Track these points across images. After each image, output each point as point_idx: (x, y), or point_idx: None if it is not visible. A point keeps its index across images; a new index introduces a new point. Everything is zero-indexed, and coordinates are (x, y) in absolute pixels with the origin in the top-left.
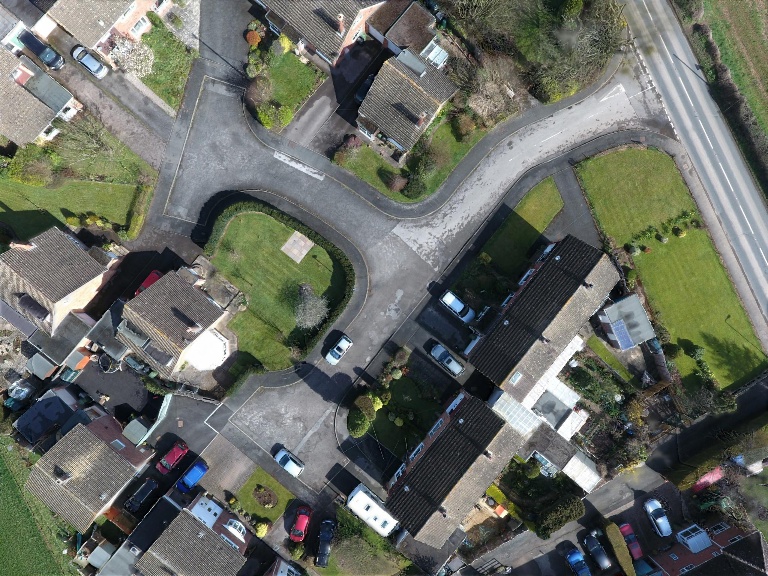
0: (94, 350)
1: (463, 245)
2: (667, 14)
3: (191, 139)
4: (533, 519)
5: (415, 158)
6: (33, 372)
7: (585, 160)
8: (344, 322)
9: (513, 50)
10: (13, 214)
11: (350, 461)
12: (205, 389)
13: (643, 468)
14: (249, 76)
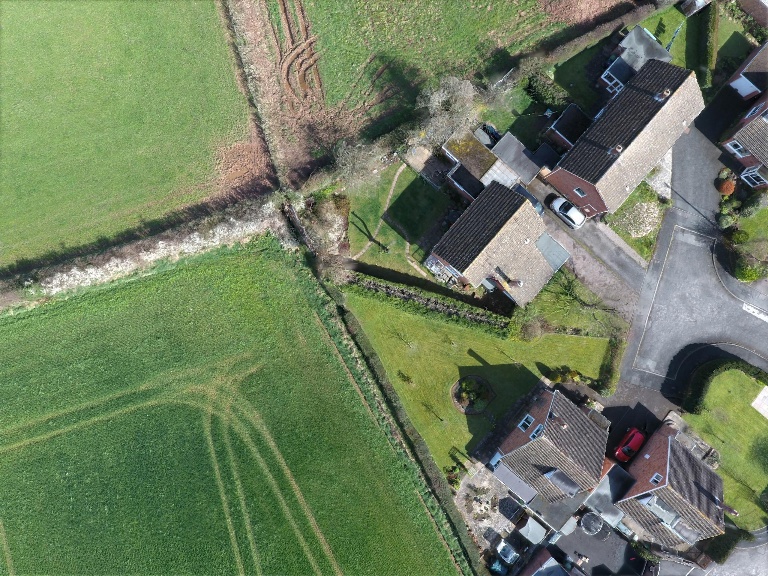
0: None
1: None
2: None
3: (661, 290)
4: None
5: None
6: (526, 536)
7: None
8: None
9: None
10: (490, 368)
11: None
12: (680, 550)
13: None
14: (722, 227)
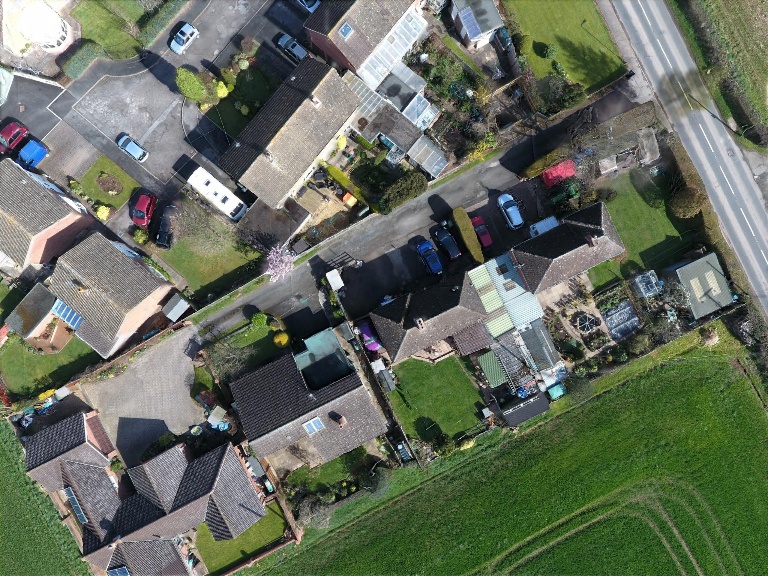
0: None
1: None
2: None
3: None
4: None
5: None
6: None
7: None
8: (191, 14)
9: None
10: None
11: (197, 152)
12: (48, 75)
13: (498, 167)
14: None
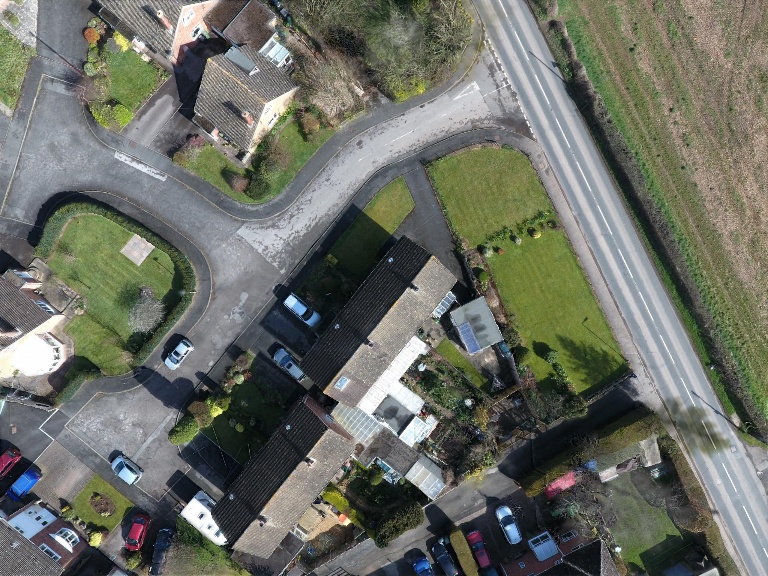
0: None
1: (310, 247)
2: (523, 10)
3: (29, 139)
4: (374, 527)
5: (261, 158)
6: None
7: (437, 160)
8: (186, 326)
9: (362, 47)
10: None
11: (191, 468)
12: (40, 395)
13: (496, 474)
14: (88, 75)
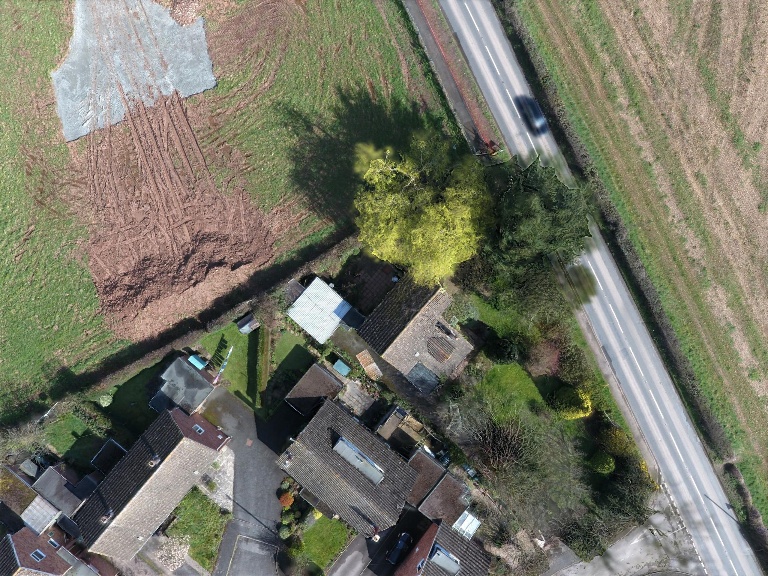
0: None
1: None
2: (698, 454)
3: None
4: None
5: None
6: None
7: None
8: None
9: (544, 500)
10: None
11: None
12: None
13: None
14: None
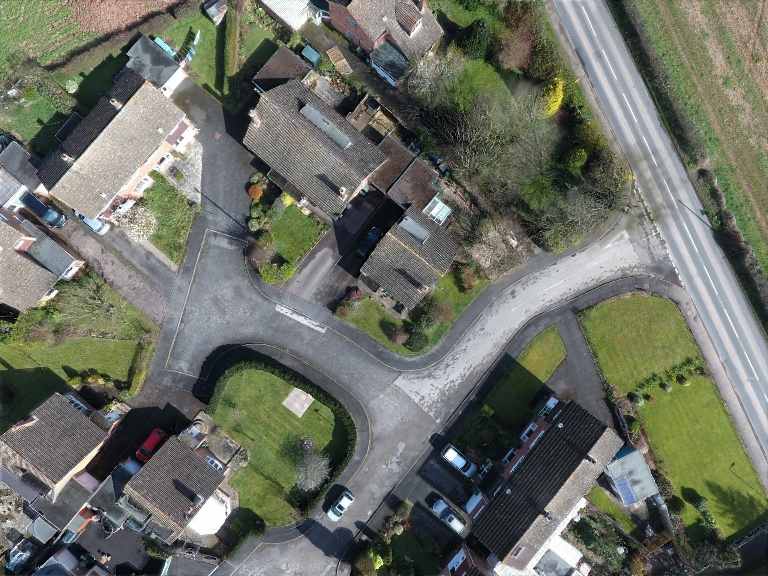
0: (96, 509)
1: (465, 396)
2: (672, 159)
3: (193, 293)
4: None
5: (417, 309)
6: (35, 536)
7: (588, 309)
8: (346, 476)
9: (516, 199)
10: (15, 372)
11: None
12: (206, 546)
13: None
14: (251, 230)
